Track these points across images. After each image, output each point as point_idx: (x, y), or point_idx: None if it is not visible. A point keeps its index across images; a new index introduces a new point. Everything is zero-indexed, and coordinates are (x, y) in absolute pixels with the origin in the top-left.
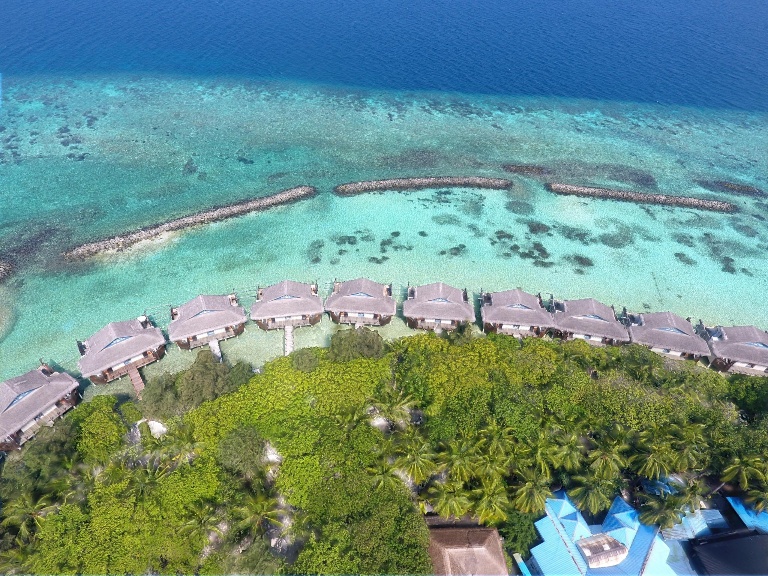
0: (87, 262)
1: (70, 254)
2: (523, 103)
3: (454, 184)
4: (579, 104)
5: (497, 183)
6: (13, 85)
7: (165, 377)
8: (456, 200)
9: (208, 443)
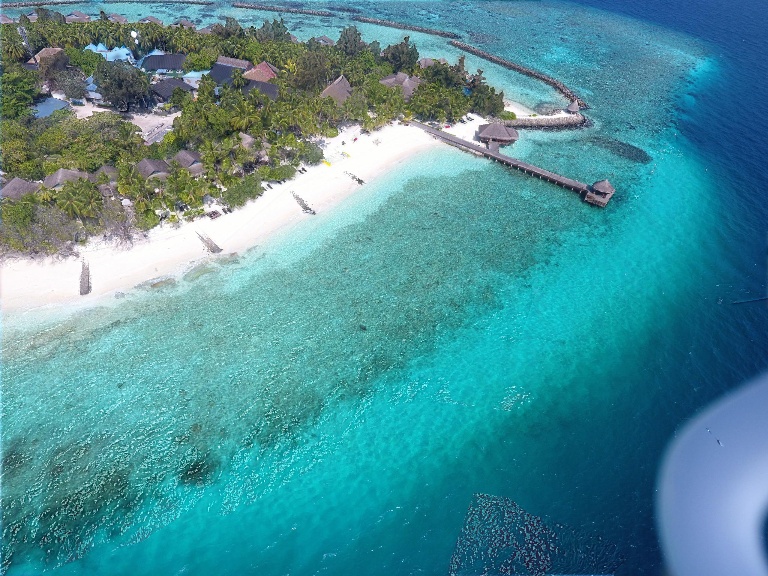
0: None
1: None
2: None
3: (177, 2)
4: None
5: (203, 2)
6: None
7: None
8: (172, 7)
9: None
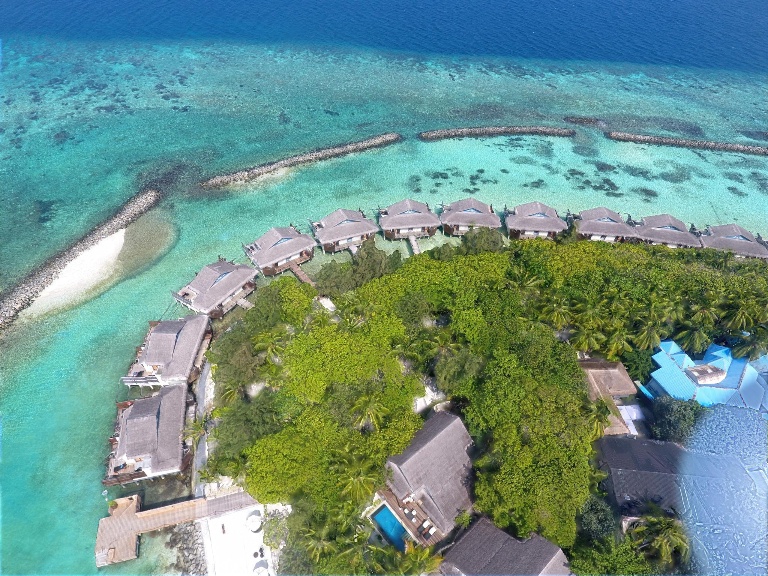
0: (222, 190)
1: (206, 184)
2: (571, 66)
3: (523, 132)
4: (623, 67)
5: (562, 131)
6: (99, 49)
7: None
8: (528, 145)
9: (384, 306)
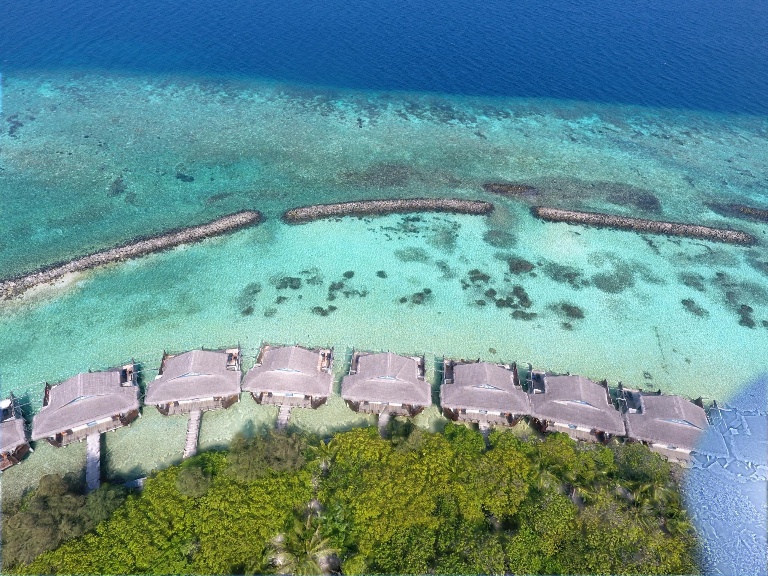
0: None
1: None
2: (512, 106)
3: (425, 208)
4: (575, 107)
5: (475, 207)
6: None
7: (1, 507)
8: (425, 229)
9: None
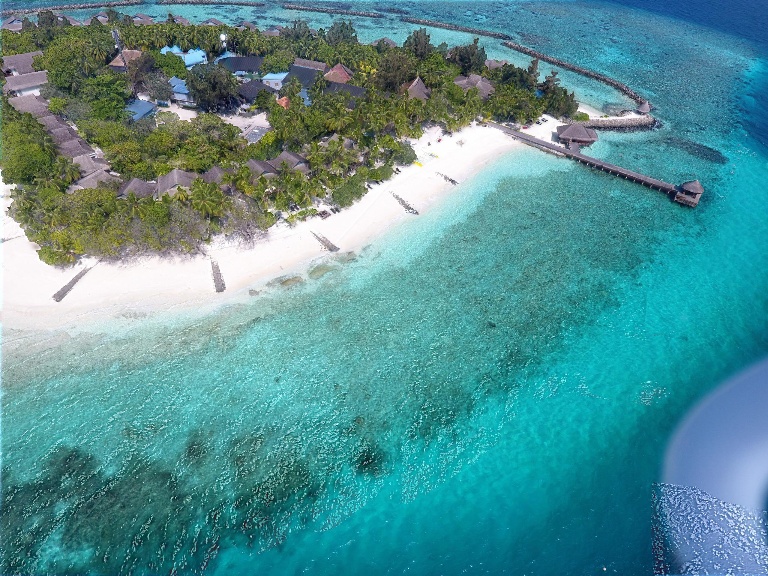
0: (7, 16)
1: None
2: None
3: (228, 3)
4: None
5: (254, 3)
6: None
7: None
8: (225, 8)
9: None
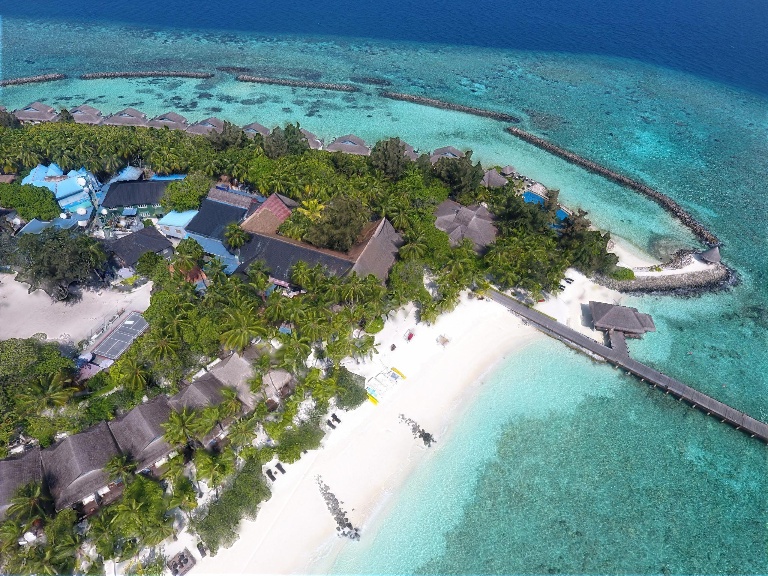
0: None
1: None
2: (280, 37)
3: (170, 75)
4: (323, 38)
5: (201, 75)
6: None
7: None
8: (163, 83)
9: None
